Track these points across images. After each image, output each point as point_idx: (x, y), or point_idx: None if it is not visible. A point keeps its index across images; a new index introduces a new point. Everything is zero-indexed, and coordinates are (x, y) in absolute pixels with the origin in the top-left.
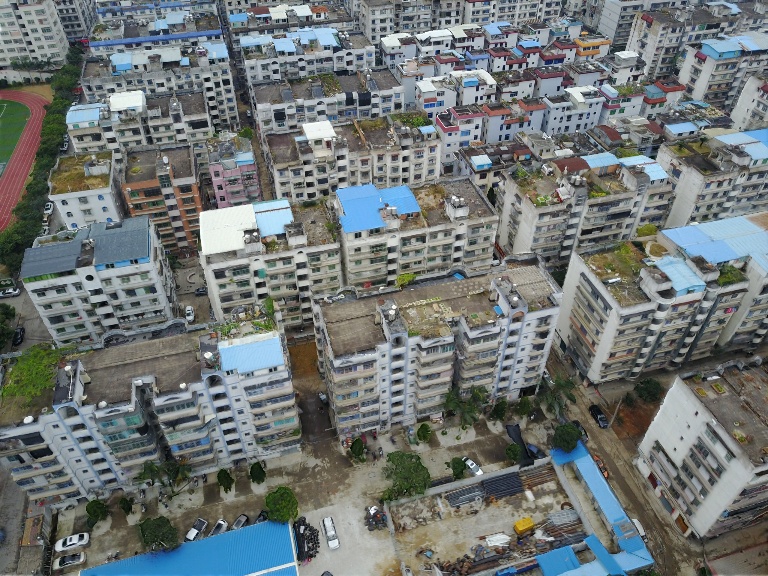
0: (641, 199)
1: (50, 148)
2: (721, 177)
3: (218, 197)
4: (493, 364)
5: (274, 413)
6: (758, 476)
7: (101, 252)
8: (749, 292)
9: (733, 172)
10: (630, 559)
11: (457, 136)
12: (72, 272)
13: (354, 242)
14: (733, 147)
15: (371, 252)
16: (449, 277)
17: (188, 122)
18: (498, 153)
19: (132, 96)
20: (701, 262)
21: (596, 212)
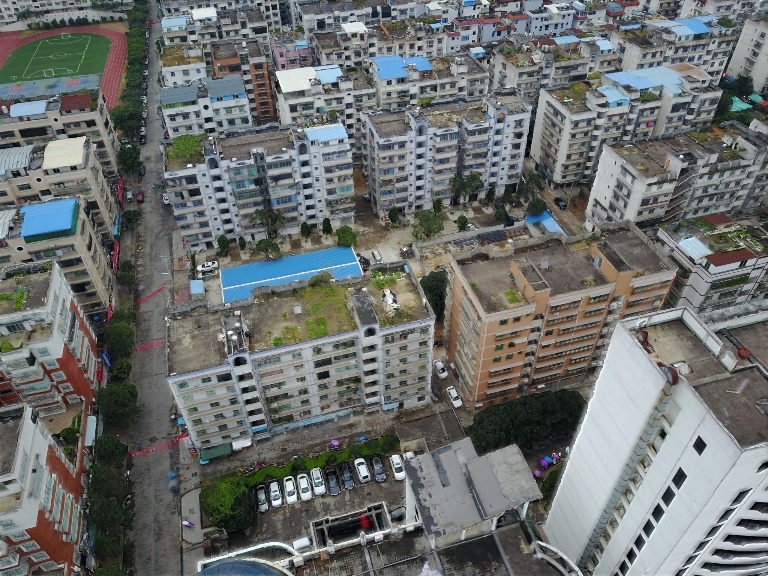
0: (594, 65)
1: (139, 58)
2: (654, 49)
3: None
4: (485, 156)
5: (339, 181)
6: (649, 186)
7: (213, 90)
8: (664, 112)
9: (663, 46)
10: None
11: (459, 40)
12: (194, 102)
13: (386, 88)
14: (663, 28)
15: (398, 97)
16: (454, 102)
17: (252, 28)
18: (490, 46)
19: (208, 10)
20: (628, 87)
21: (561, 74)
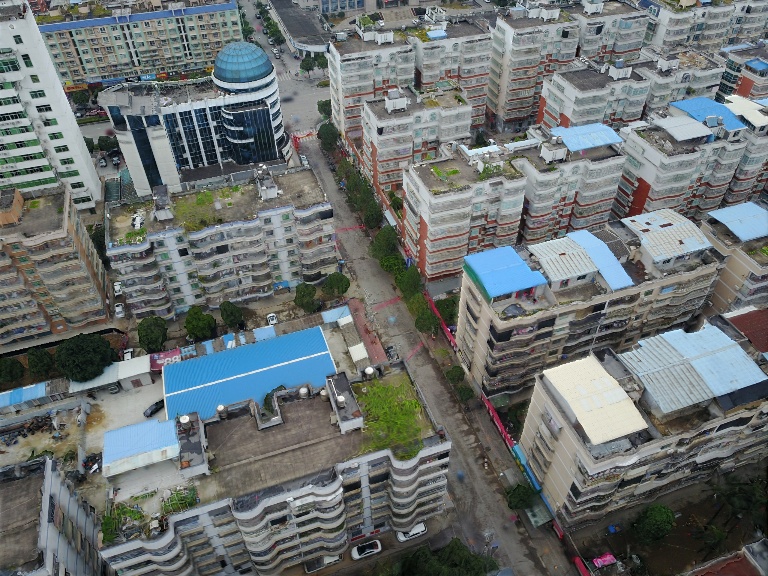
0: None
1: None
2: None
3: None
4: None
5: None
6: None
7: None
8: None
9: None
10: None
11: None
12: None
13: None
14: None
15: None
16: None
17: None
18: None
19: None
20: None
21: None
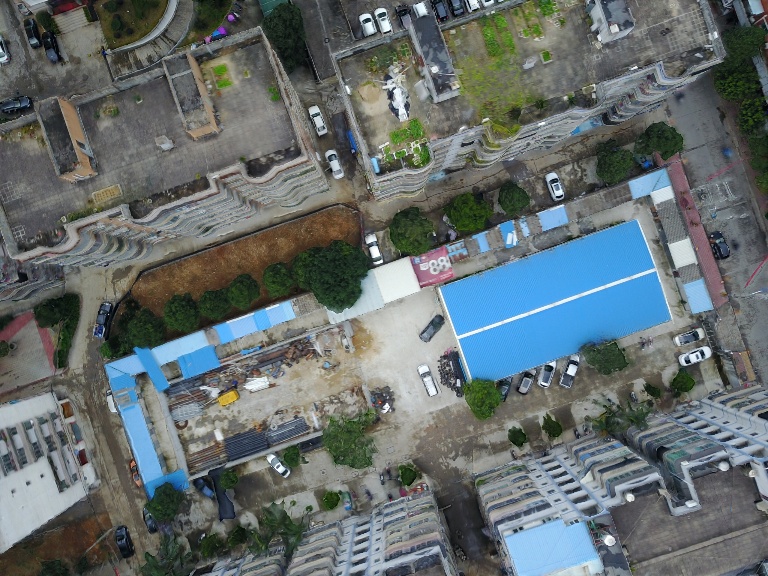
0: None
1: None
2: None
3: None
4: None
5: None
6: None
7: None
8: None
9: None
10: (128, 367)
11: None
12: None
13: None
14: None
15: None
16: None
17: None
18: None
19: None
20: None
21: None
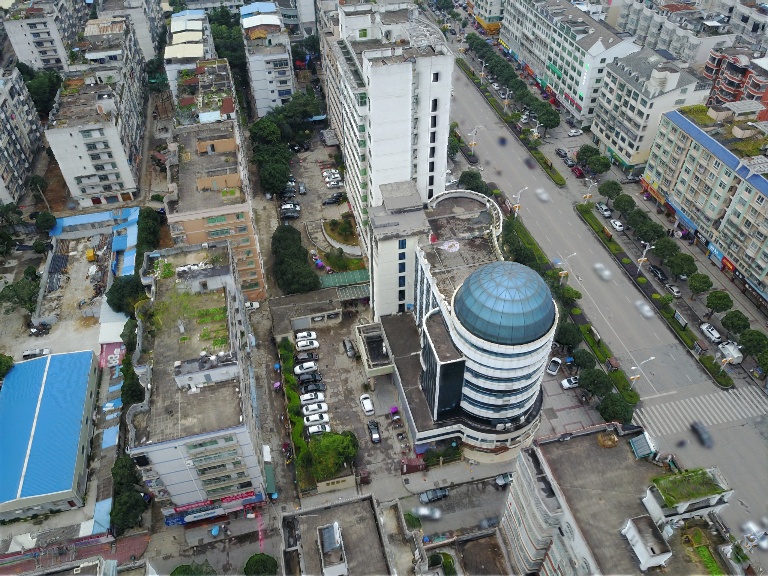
0: None
1: None
2: None
3: None
4: None
5: None
6: None
7: None
8: None
9: None
10: (133, 215)
11: None
12: None
13: None
14: None
15: None
16: None
17: None
18: None
19: None
20: None
21: None
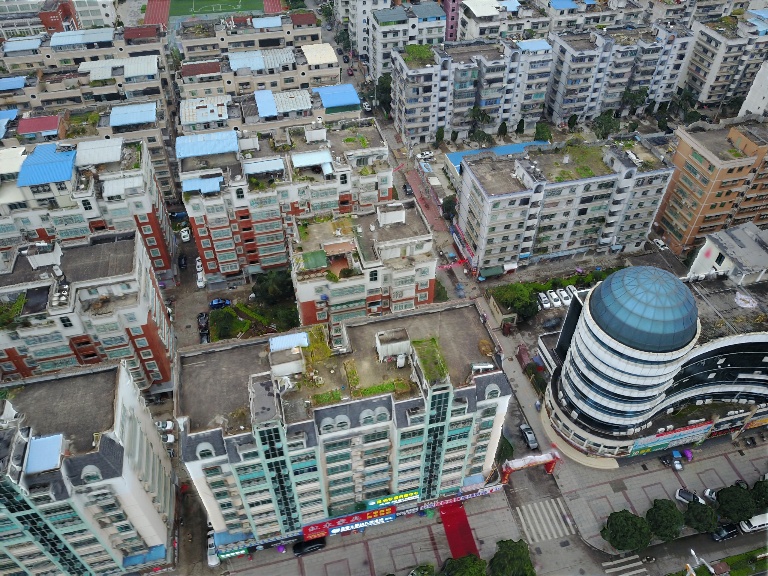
0: (729, 6)
1: None
2: None
3: (451, 8)
4: (652, 73)
5: (535, 88)
6: None
7: (418, 13)
8: None
9: None
10: None
11: None
12: (405, 22)
13: (559, 17)
14: None
15: (567, 26)
16: (624, 29)
17: None
18: None
19: None
20: None
21: (701, 13)
